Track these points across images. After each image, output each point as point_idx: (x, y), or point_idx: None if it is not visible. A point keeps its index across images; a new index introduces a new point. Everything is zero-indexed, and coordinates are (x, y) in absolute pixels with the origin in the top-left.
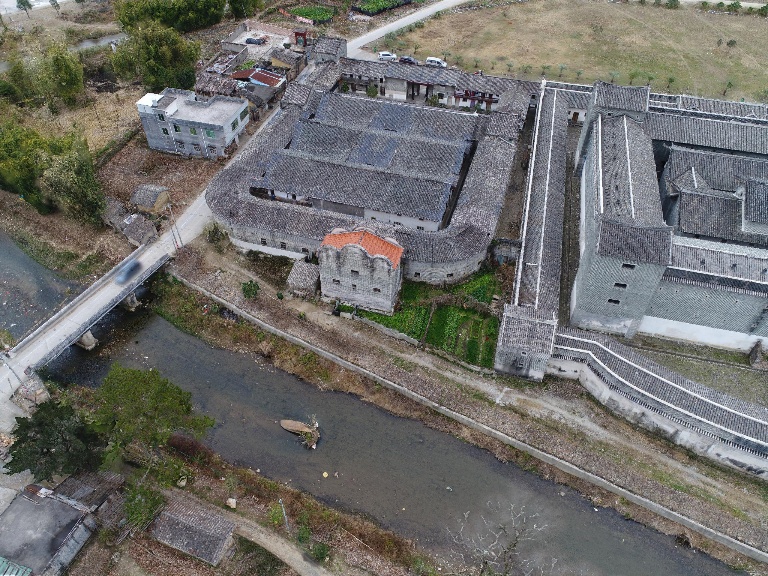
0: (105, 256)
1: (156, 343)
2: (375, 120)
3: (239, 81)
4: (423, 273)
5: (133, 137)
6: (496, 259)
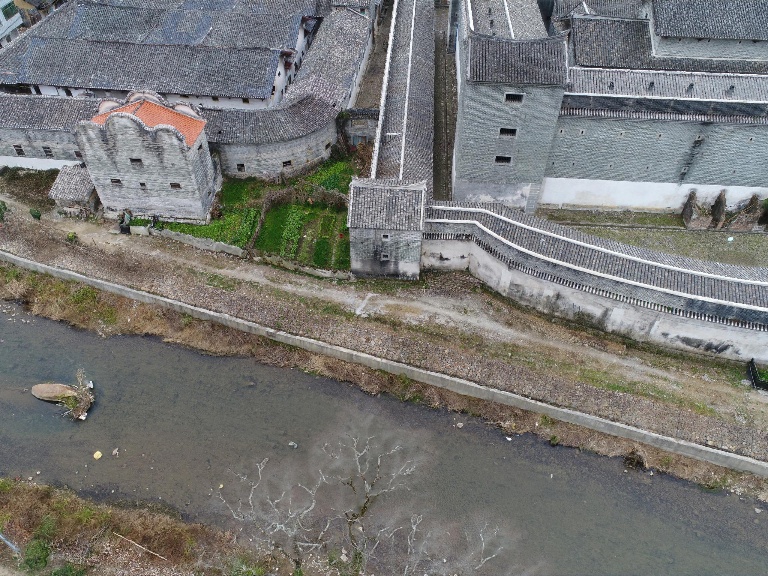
0: None
1: None
2: (188, 3)
3: None
4: (248, 163)
5: None
6: (351, 142)
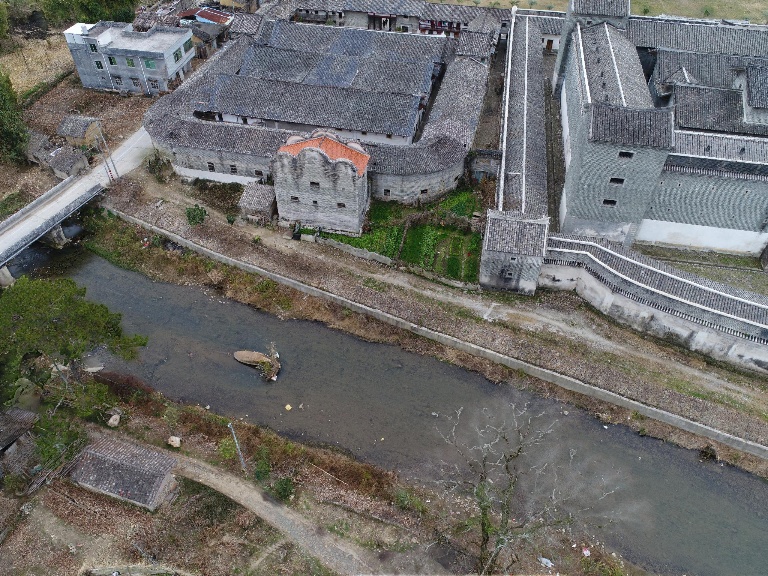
0: (29, 194)
1: (87, 280)
2: (334, 46)
3: (184, 20)
4: (393, 190)
5: (65, 78)
6: (474, 176)
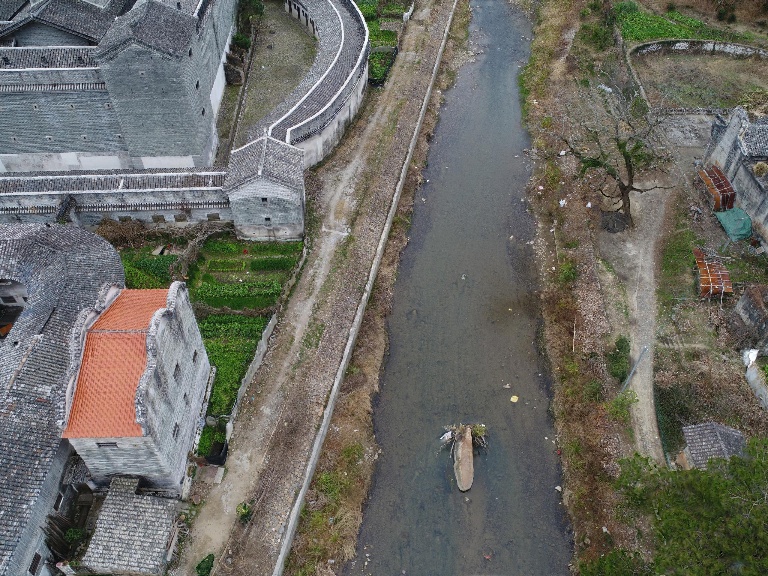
0: None
1: None
2: None
3: None
4: None
5: None
6: None
